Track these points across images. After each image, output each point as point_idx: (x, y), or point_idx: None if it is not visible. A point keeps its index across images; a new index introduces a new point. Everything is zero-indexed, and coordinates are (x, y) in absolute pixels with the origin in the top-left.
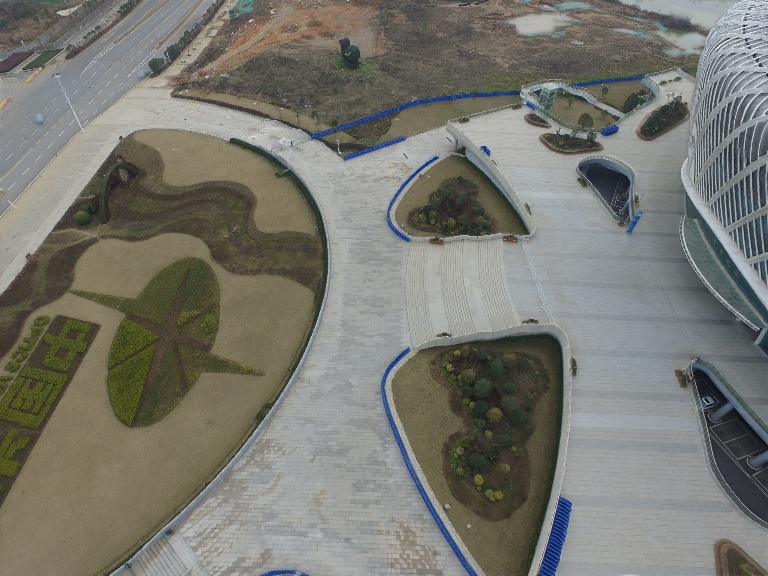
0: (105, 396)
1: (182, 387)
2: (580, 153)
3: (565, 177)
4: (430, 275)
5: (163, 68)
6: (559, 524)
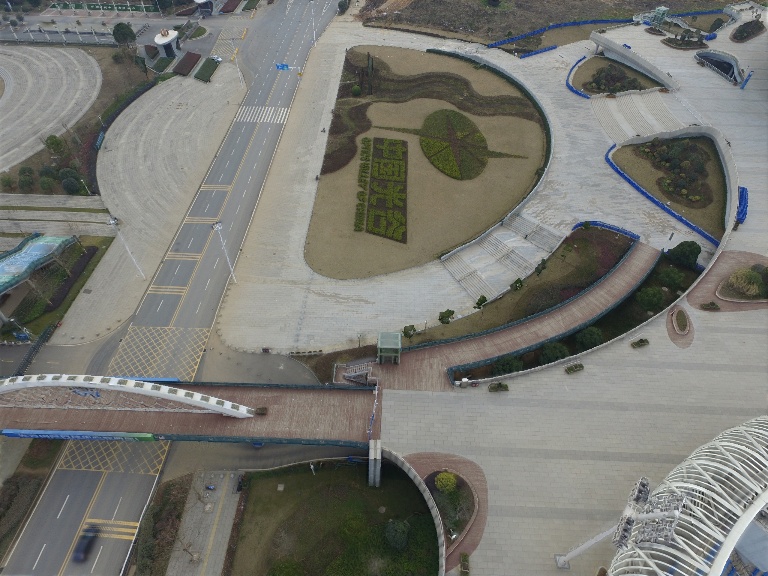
0: (435, 169)
1: (481, 164)
2: (693, 49)
3: (688, 62)
4: (614, 112)
5: (345, 9)
6: (743, 195)
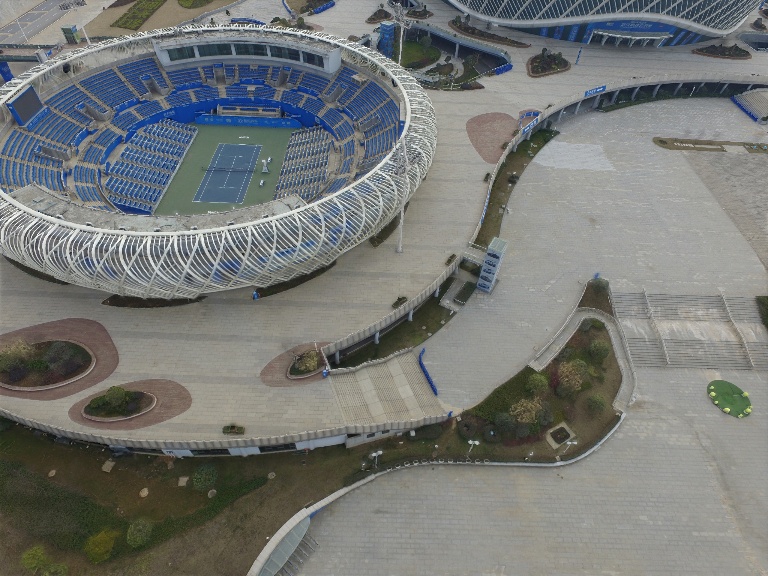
0: None
1: (207, 2)
2: None
3: None
4: None
5: None
6: (328, 3)
